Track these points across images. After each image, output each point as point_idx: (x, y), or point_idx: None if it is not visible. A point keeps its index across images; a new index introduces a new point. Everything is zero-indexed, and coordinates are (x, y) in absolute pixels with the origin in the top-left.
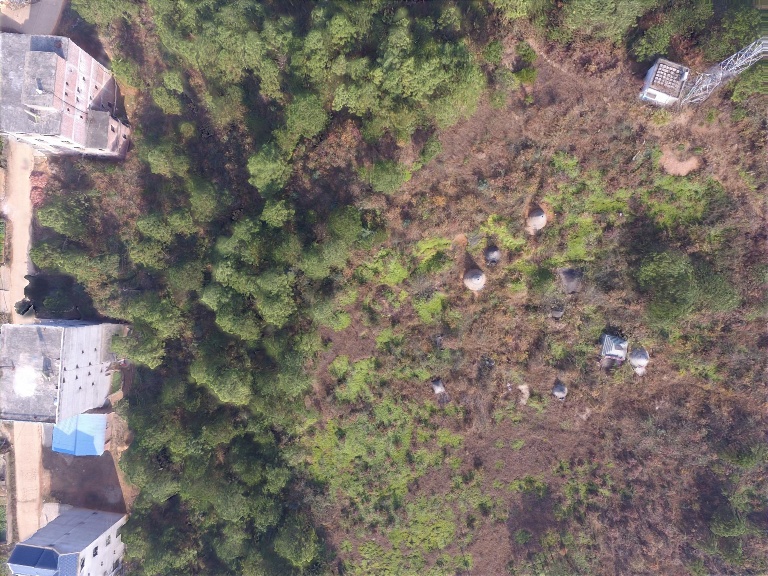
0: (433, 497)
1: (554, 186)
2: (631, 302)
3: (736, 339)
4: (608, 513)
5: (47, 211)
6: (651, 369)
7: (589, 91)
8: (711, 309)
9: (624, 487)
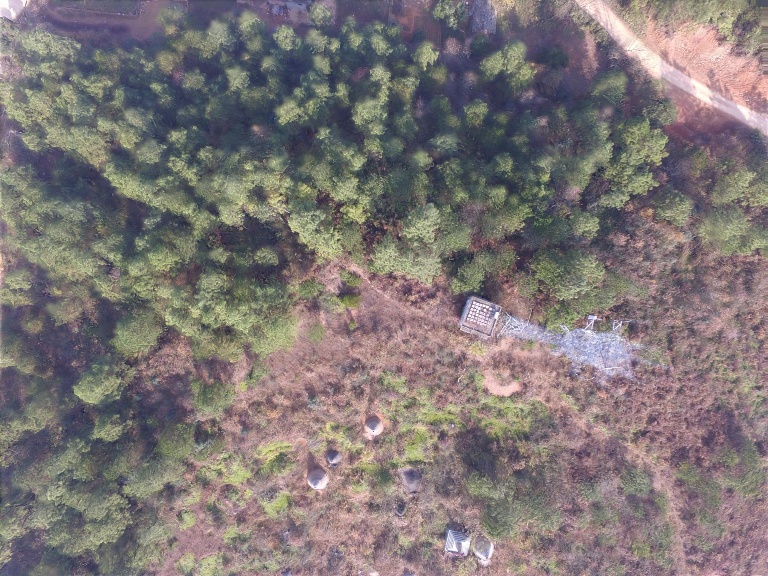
0: None
1: (385, 400)
2: (468, 506)
3: (573, 537)
4: None
5: None
6: (495, 561)
7: (411, 318)
8: (543, 516)
9: None
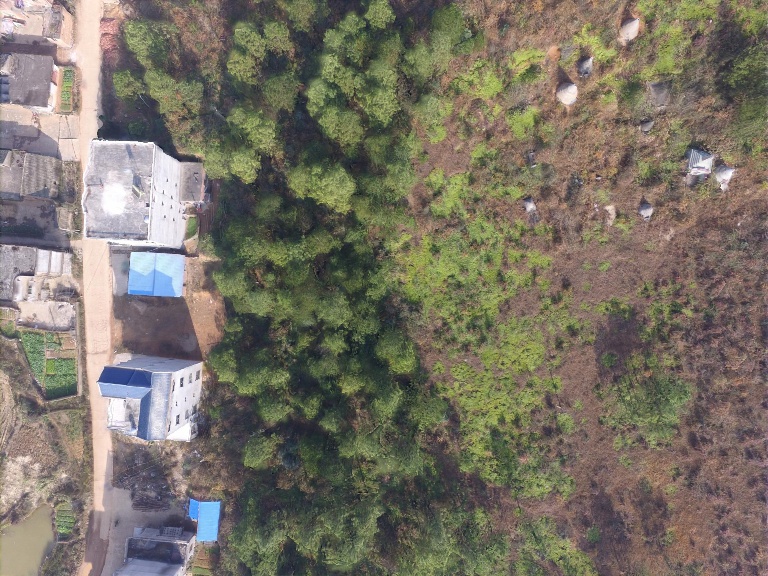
0: (523, 318)
1: None
2: (719, 110)
3: None
4: (692, 332)
5: (137, 26)
6: (734, 184)
7: None
8: None
9: (706, 306)
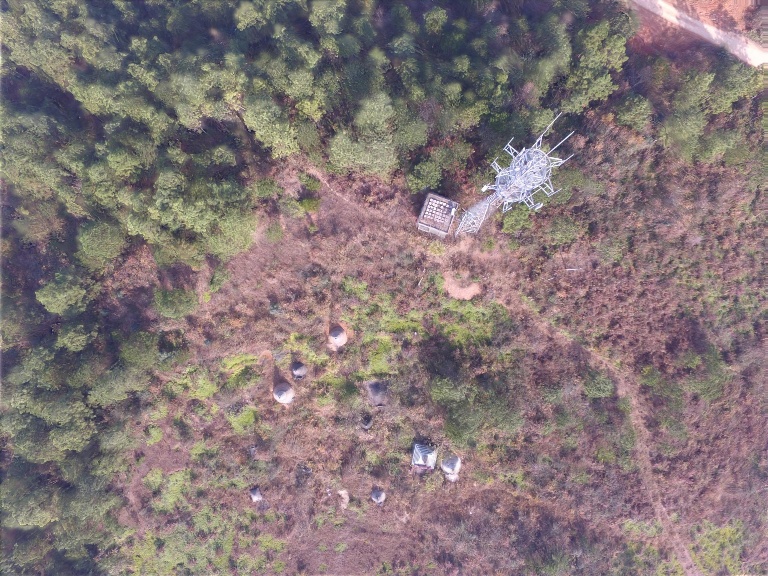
0: None
1: (348, 308)
2: (432, 416)
3: (539, 449)
4: None
5: None
6: (463, 476)
7: (371, 220)
8: (507, 424)
9: None
